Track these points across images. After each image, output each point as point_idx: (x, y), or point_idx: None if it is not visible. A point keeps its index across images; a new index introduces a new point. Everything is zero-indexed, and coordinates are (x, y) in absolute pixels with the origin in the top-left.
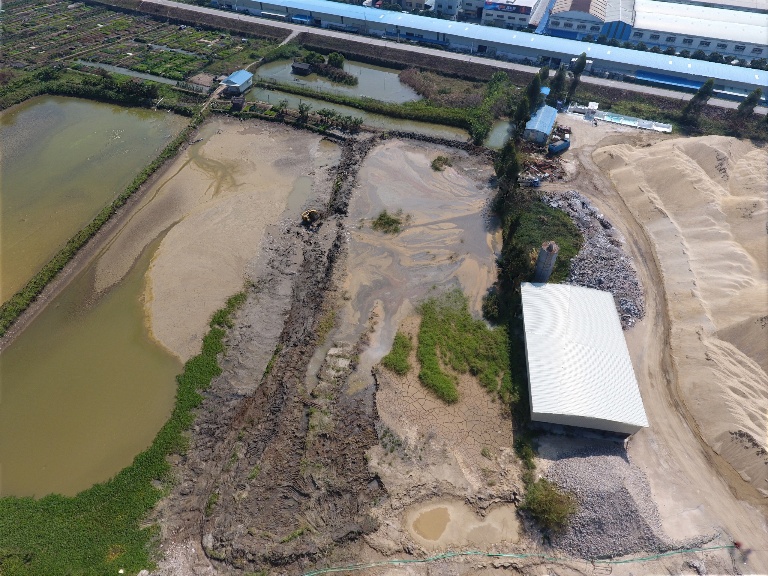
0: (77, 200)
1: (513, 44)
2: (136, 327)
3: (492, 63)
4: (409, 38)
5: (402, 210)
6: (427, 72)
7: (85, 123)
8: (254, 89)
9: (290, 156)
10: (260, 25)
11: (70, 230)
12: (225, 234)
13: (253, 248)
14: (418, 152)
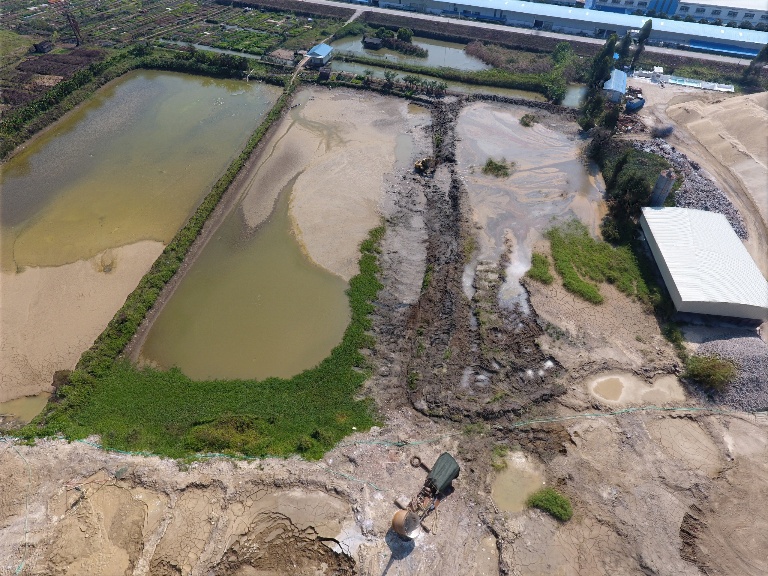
0: (204, 155)
1: (570, 18)
2: (295, 254)
3: (552, 35)
4: (467, 15)
5: (505, 158)
6: (491, 45)
7: (186, 92)
8: (332, 62)
9: (385, 117)
10: (324, 6)
11: (207, 179)
12: (348, 181)
13: (377, 192)
14: (504, 112)
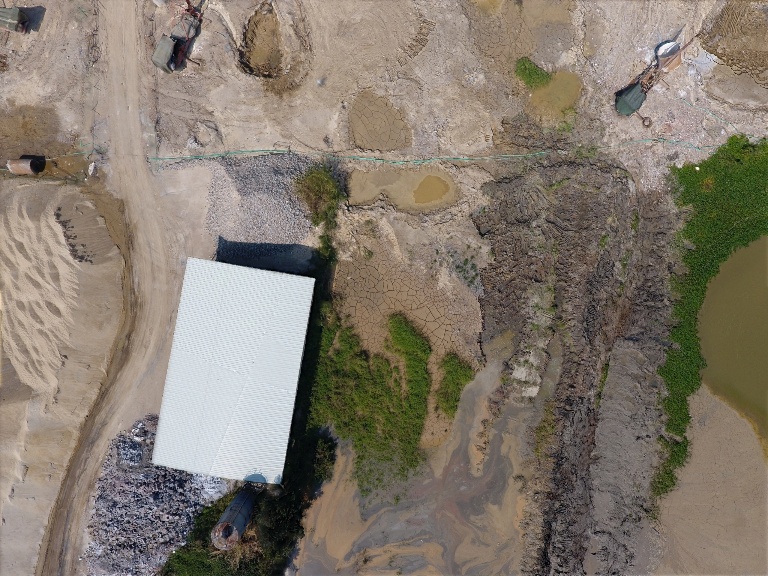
0: None
1: None
2: None
3: None
4: None
5: None
6: None
7: None
8: None
9: None
10: None
11: None
12: None
13: None
14: None
